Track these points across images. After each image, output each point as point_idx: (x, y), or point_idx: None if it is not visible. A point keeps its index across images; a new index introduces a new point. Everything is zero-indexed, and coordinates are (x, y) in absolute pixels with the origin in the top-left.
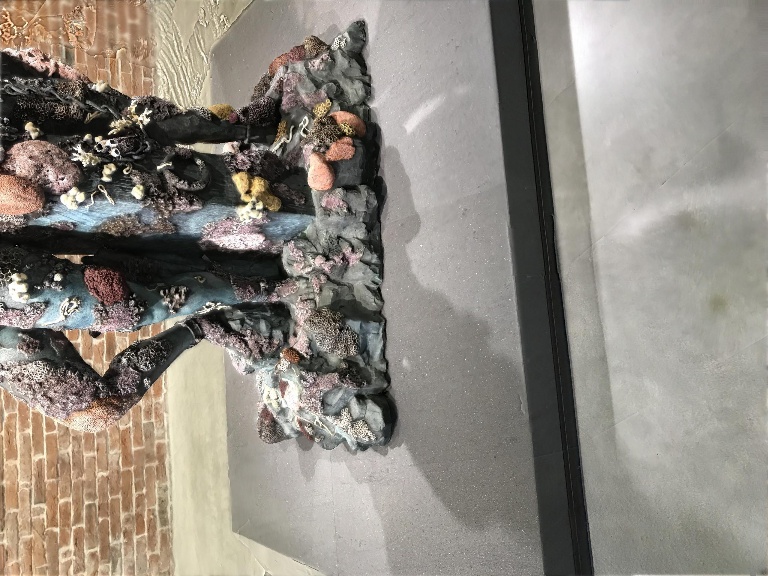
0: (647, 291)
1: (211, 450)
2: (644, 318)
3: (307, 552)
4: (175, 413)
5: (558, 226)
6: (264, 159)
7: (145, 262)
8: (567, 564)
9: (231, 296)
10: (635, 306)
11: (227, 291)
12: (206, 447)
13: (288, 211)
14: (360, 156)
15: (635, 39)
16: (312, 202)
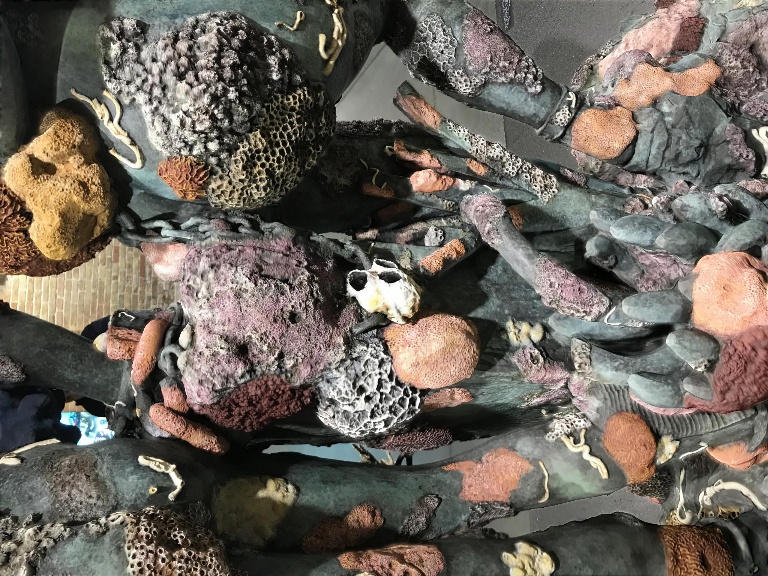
0: None
1: None
2: None
3: None
4: None
5: None
6: None
7: None
8: None
9: None
10: None
11: None
12: None
13: None
14: None
15: None
16: None
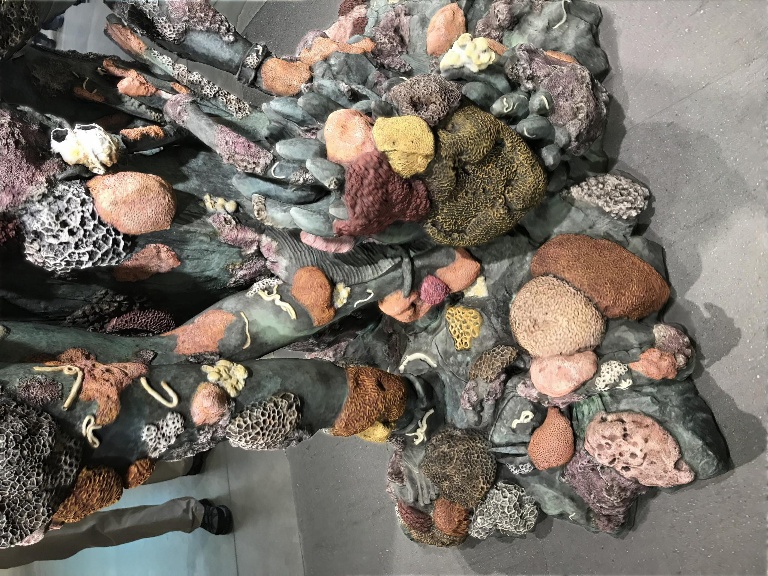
0: None
1: None
2: None
3: None
4: None
5: None
6: None
7: None
8: None
9: None
10: None
11: None
12: None
13: None
14: None
15: None
16: None
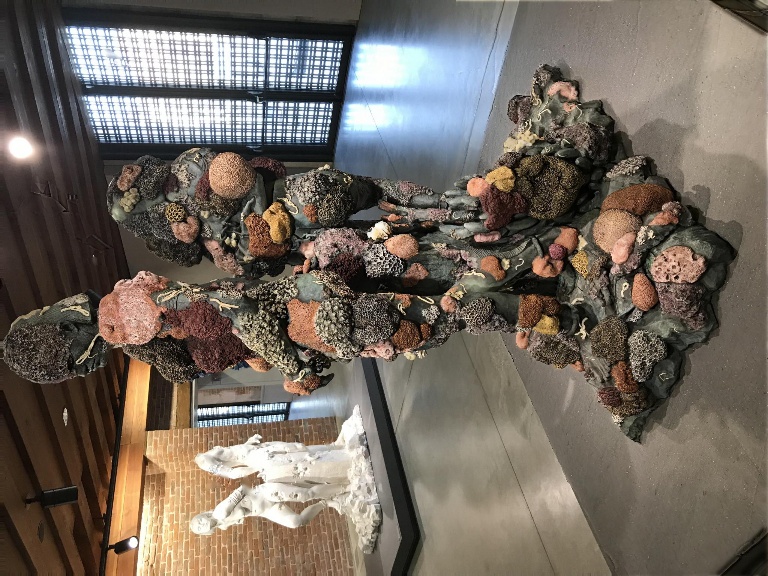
0: None
1: None
2: None
3: None
4: None
5: None
6: None
7: None
8: None
9: None
10: None
11: None
12: None
13: None
14: None
15: (560, 469)
16: None
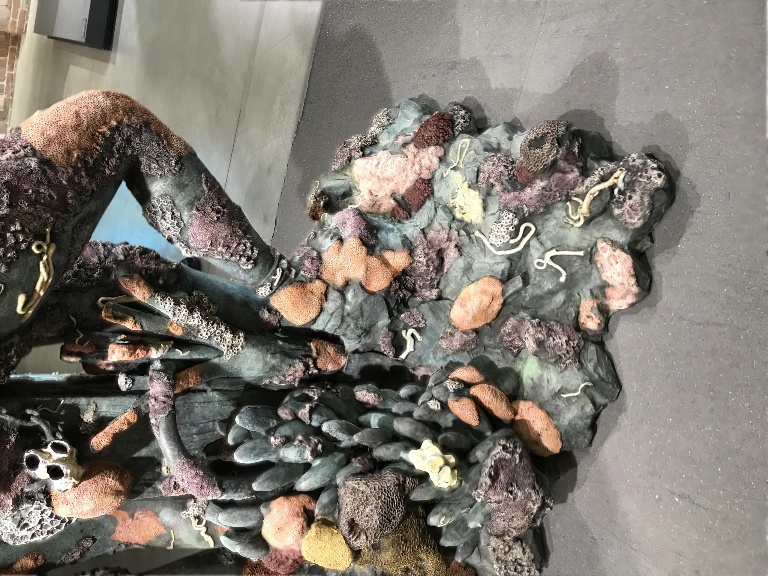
0: None
1: None
2: None
3: None
4: None
5: None
6: None
7: None
8: None
9: None
10: None
11: None
12: None
13: None
14: None
15: None
16: None
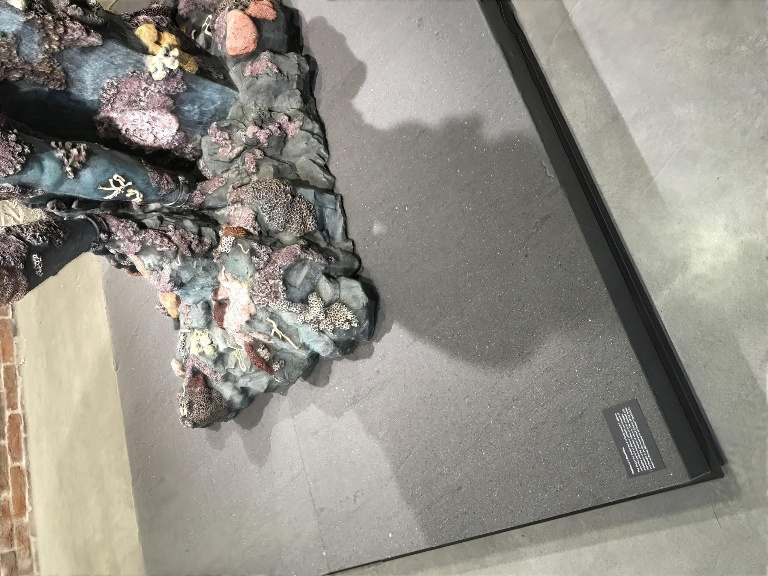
0: (648, 19)
1: (104, 549)
2: (653, 47)
3: (274, 566)
4: (46, 531)
5: (523, 20)
6: (171, 25)
7: (24, 127)
8: (652, 354)
9: (144, 178)
10: (638, 44)
11: (139, 169)
12: (96, 549)
13: (207, 78)
14: (283, 21)
15: None
16: (232, 81)
